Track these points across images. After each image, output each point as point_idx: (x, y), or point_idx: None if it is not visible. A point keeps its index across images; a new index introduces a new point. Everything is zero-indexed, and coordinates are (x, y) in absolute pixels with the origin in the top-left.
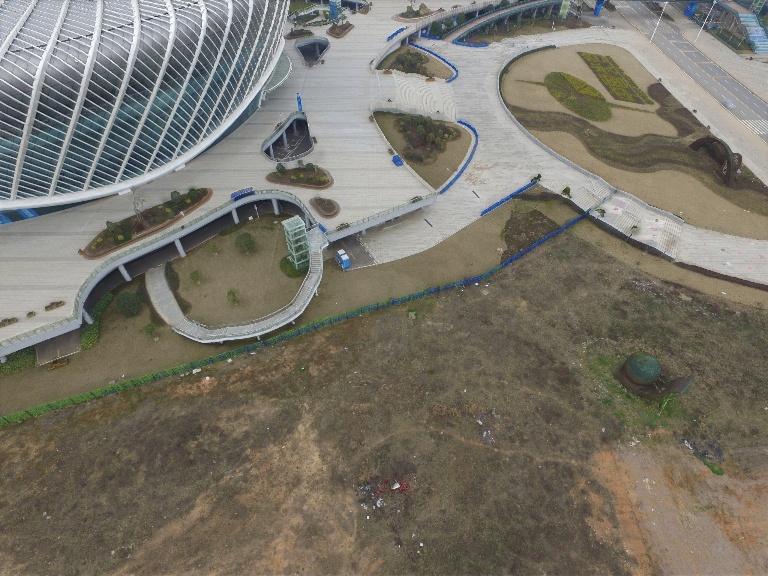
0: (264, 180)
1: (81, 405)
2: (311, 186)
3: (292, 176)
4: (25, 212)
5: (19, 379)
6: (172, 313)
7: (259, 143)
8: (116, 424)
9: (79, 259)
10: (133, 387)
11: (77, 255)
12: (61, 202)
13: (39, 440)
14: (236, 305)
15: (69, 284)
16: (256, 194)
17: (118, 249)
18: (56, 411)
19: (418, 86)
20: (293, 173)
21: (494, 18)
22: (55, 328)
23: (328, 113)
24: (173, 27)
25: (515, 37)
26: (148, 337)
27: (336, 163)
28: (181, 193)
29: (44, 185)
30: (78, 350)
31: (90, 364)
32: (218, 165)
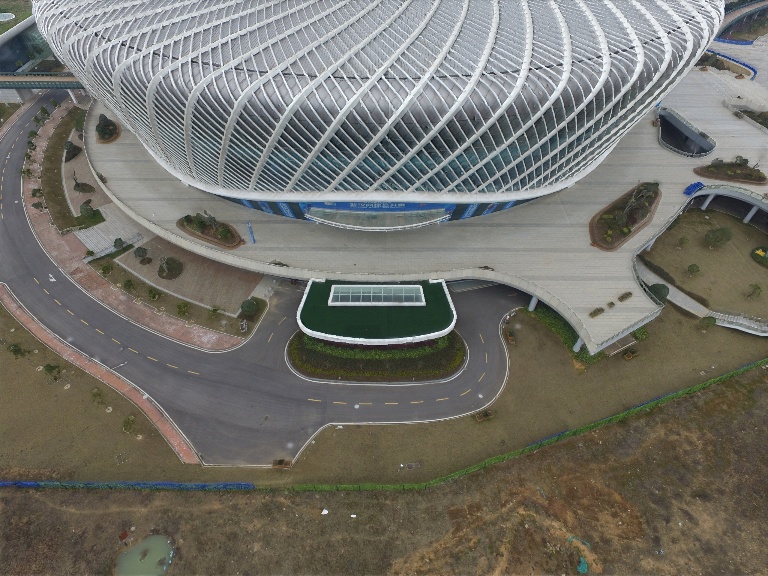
0: (696, 175)
1: (694, 395)
2: (752, 182)
3: (729, 172)
4: (509, 203)
5: (606, 368)
6: (693, 306)
7: (650, 138)
8: (752, 414)
9: (597, 251)
10: (728, 378)
11: (591, 247)
12: (545, 194)
13: (690, 428)
14: (750, 299)
15: (614, 275)
16: (705, 189)
17: (625, 241)
18: (674, 400)
19: (740, 83)
20: (726, 169)
21: (742, 16)
22: (647, 319)
23: (686, 109)
24: (718, 21)
25: (764, 35)
26: (693, 329)
27: (749, 159)
28: (627, 187)
29: (550, 177)
30: (634, 341)
31: (662, 355)
32: (633, 159)
